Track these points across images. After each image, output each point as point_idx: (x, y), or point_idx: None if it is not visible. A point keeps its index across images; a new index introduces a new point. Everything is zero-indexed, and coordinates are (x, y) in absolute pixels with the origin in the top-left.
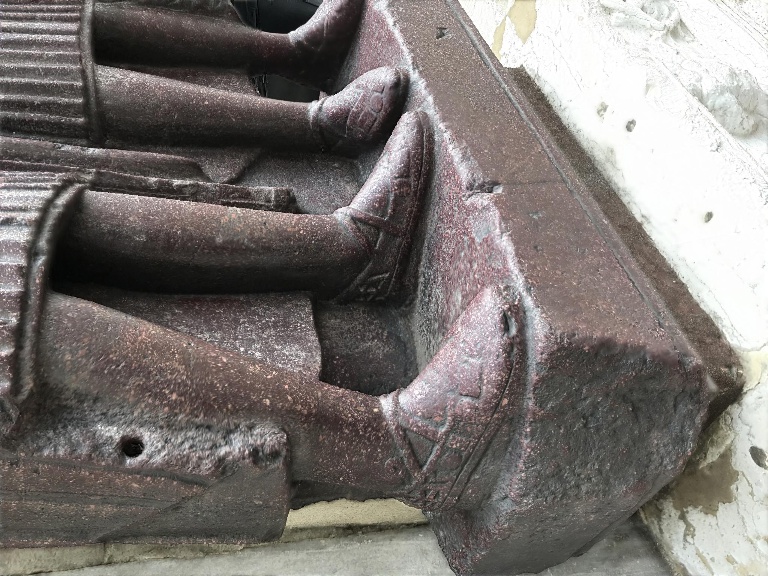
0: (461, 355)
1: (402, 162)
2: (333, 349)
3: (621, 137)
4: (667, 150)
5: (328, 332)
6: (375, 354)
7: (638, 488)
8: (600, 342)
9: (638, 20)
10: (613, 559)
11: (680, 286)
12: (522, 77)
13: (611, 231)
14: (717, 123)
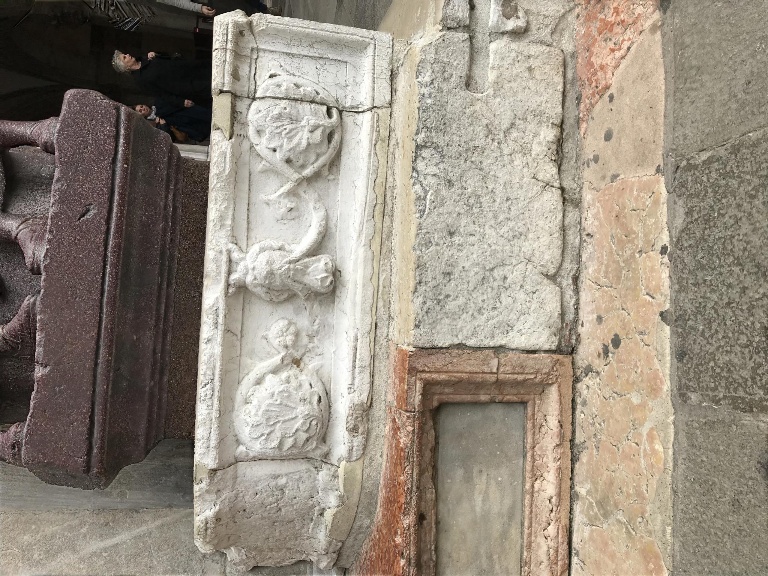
0: (5, 445)
1: (20, 328)
2: (9, 375)
3: None
4: None
5: (6, 368)
6: (32, 378)
7: (86, 489)
8: (47, 463)
9: (279, 170)
10: (168, 456)
11: (194, 382)
12: (202, 179)
13: (105, 393)
14: (221, 321)
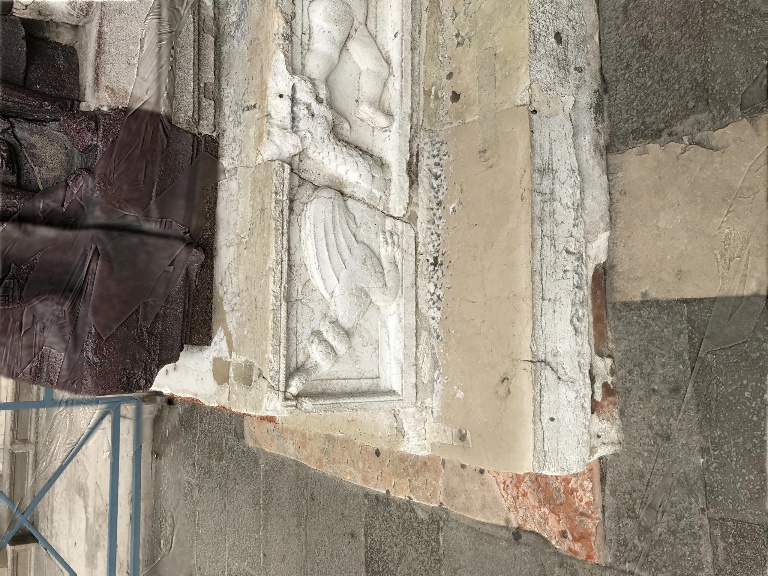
0: None
1: None
2: None
3: (167, 365)
4: None
5: None
6: None
7: None
8: None
9: None
10: None
11: None
12: None
13: None
14: None
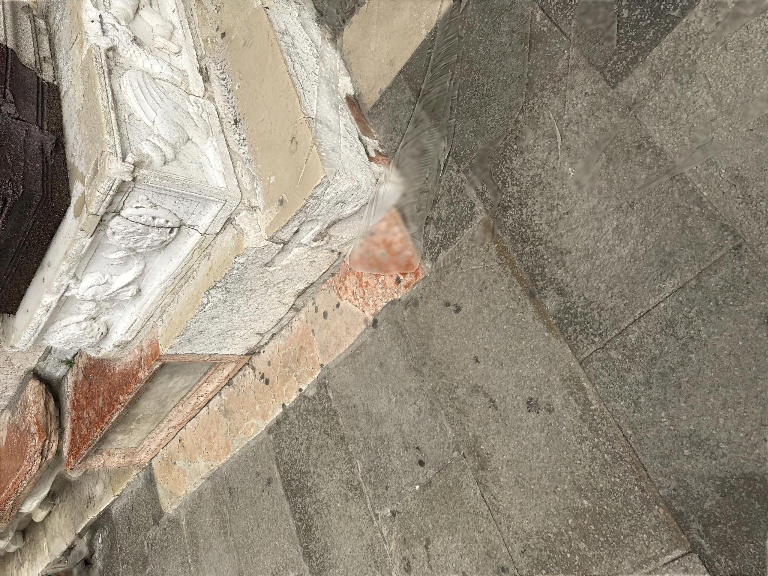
0: None
1: None
2: None
3: None
4: (37, 296)
5: None
6: None
7: None
8: None
9: None
10: None
11: (21, 297)
12: None
13: None
14: None
